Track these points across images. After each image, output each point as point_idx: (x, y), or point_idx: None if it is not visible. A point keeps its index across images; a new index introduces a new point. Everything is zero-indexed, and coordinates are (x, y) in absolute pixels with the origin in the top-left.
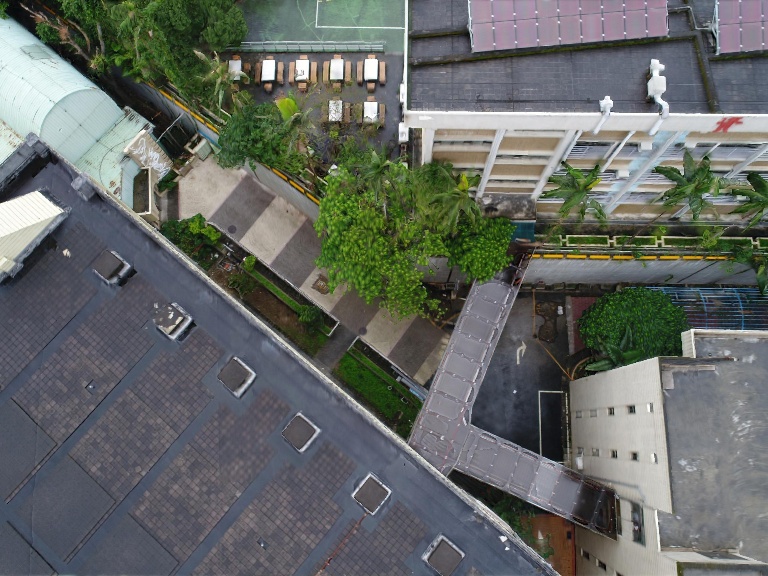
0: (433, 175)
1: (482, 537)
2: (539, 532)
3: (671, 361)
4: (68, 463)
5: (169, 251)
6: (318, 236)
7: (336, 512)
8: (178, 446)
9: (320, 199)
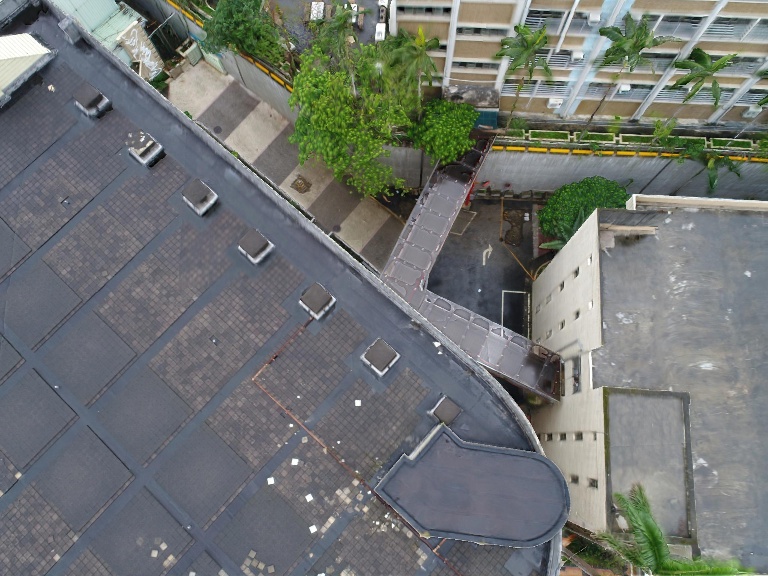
0: (398, 46)
1: (417, 342)
2: None
3: (611, 216)
4: (41, 266)
5: (144, 84)
6: (291, 110)
7: (284, 316)
8: (142, 255)
9: (295, 77)
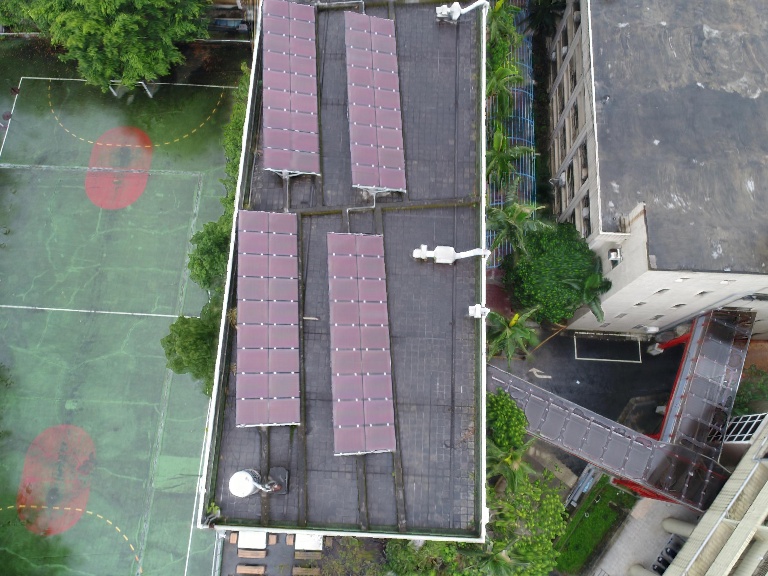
0: None
1: None
2: None
3: None
4: None
5: None
6: None
7: None
8: None
9: None
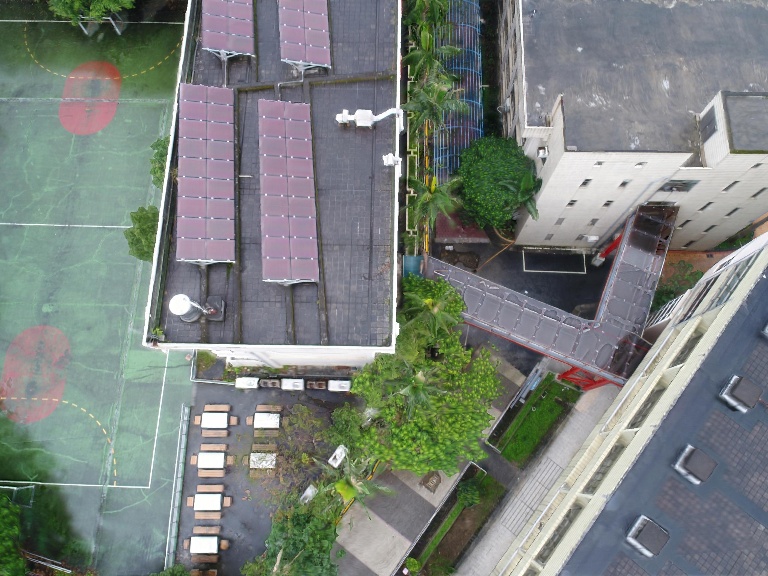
0: None
1: (759, 297)
2: None
3: None
4: None
5: None
6: None
7: (761, 428)
8: None
9: None
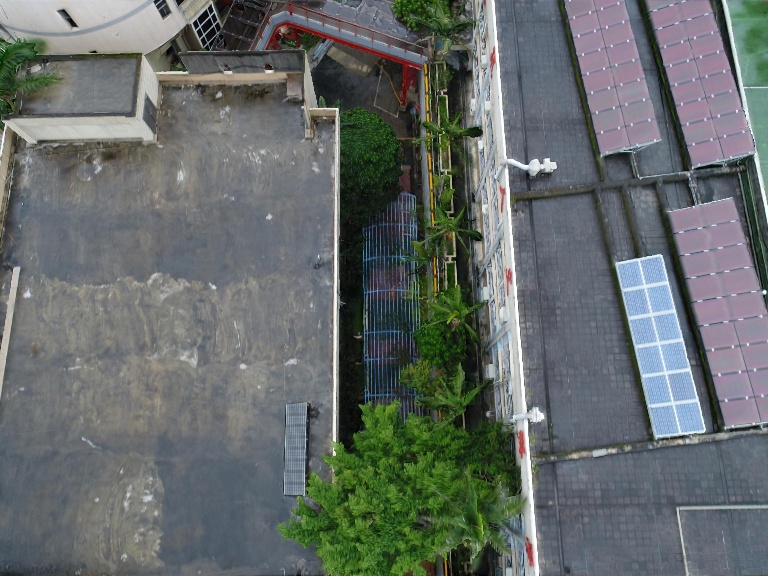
0: None
1: None
2: None
3: None
4: None
5: None
6: None
7: None
8: None
9: None
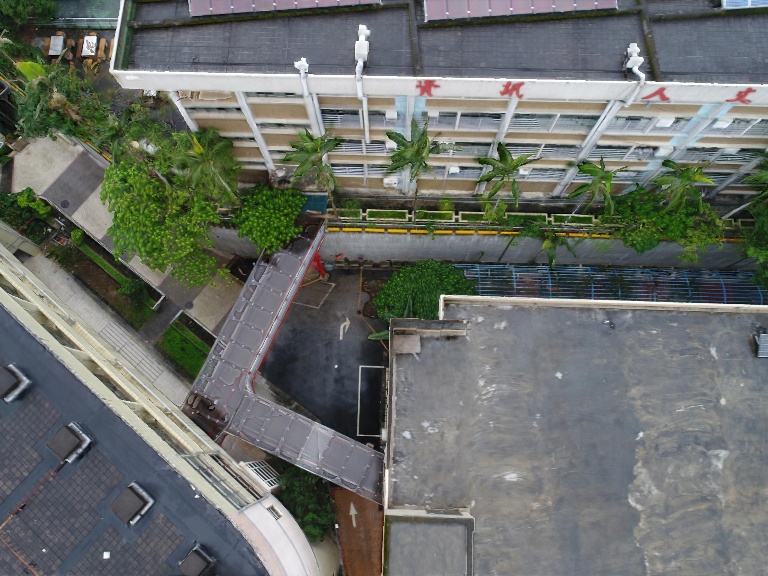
0: None
1: (174, 485)
2: (351, 504)
3: (410, 324)
4: None
5: None
6: None
7: (35, 460)
8: None
9: None
